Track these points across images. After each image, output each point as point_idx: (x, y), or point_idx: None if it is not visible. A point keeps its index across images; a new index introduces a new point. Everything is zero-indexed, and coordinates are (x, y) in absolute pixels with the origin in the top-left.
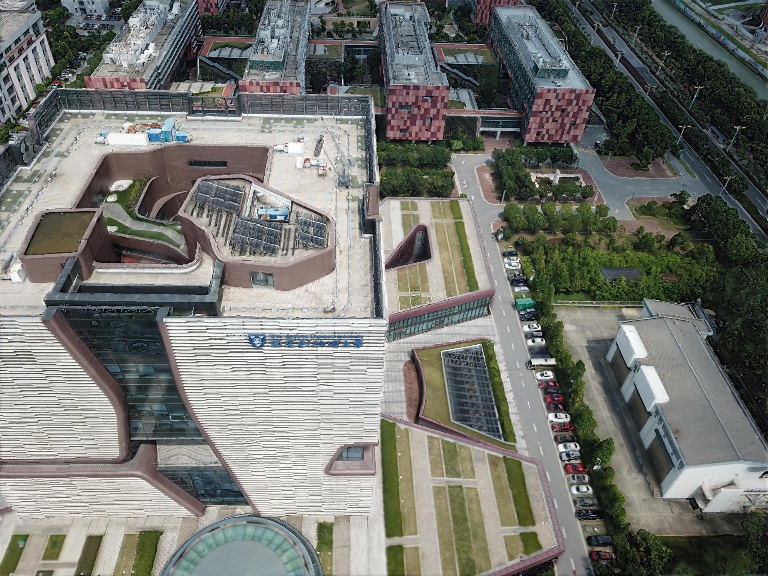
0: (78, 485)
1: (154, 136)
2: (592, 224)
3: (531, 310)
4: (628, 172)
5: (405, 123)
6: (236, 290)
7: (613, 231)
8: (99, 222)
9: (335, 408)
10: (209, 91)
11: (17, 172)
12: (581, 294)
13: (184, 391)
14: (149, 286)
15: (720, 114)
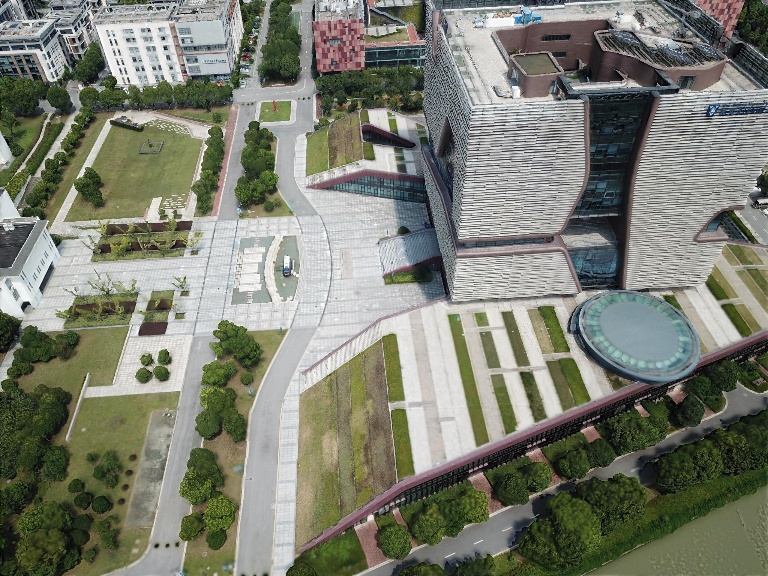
0: (514, 263)
1: (518, 19)
2: None
3: None
4: None
5: None
6: None
7: None
8: None
9: (732, 172)
10: (397, 32)
11: None
12: None
13: (639, 162)
14: None
15: None
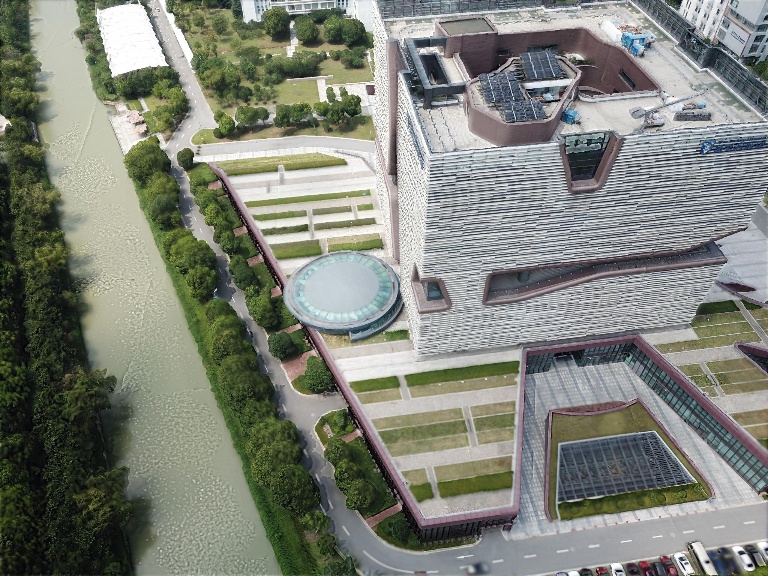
0: None
1: (624, 38)
2: None
3: None
4: None
5: None
6: (460, 110)
7: None
8: (486, 37)
9: None
10: None
11: (538, 8)
12: None
13: None
14: (445, 75)
15: None
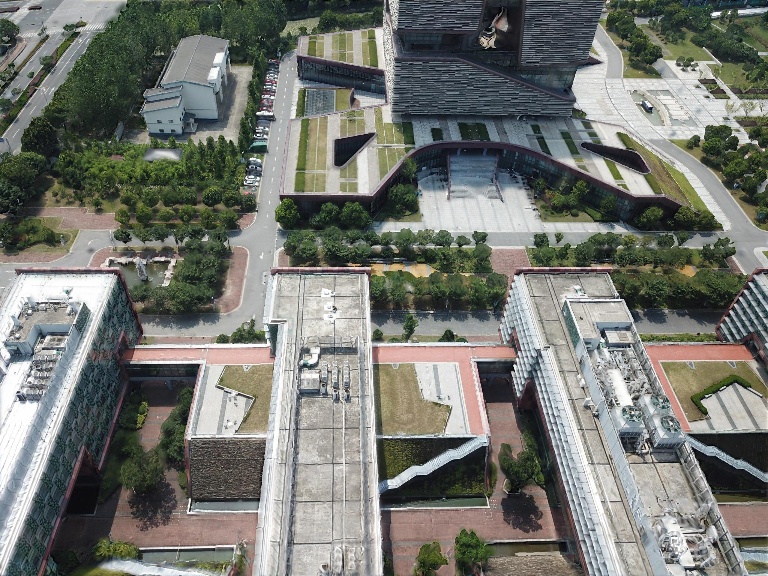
0: None
1: None
2: None
3: None
4: None
5: None
6: None
7: None
8: None
9: None
10: (701, 394)
11: None
12: None
13: None
14: None
15: None
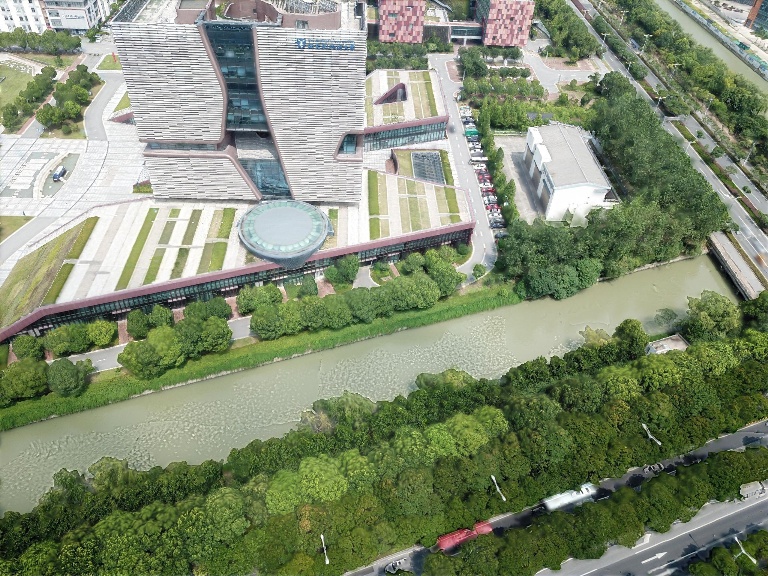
0: (193, 166)
1: None
2: (525, 90)
3: (476, 136)
4: (561, 67)
5: (393, 28)
6: None
7: (541, 96)
8: (213, 2)
9: (340, 99)
10: None
11: None
12: (512, 130)
13: (261, 83)
14: None
15: (639, 31)
